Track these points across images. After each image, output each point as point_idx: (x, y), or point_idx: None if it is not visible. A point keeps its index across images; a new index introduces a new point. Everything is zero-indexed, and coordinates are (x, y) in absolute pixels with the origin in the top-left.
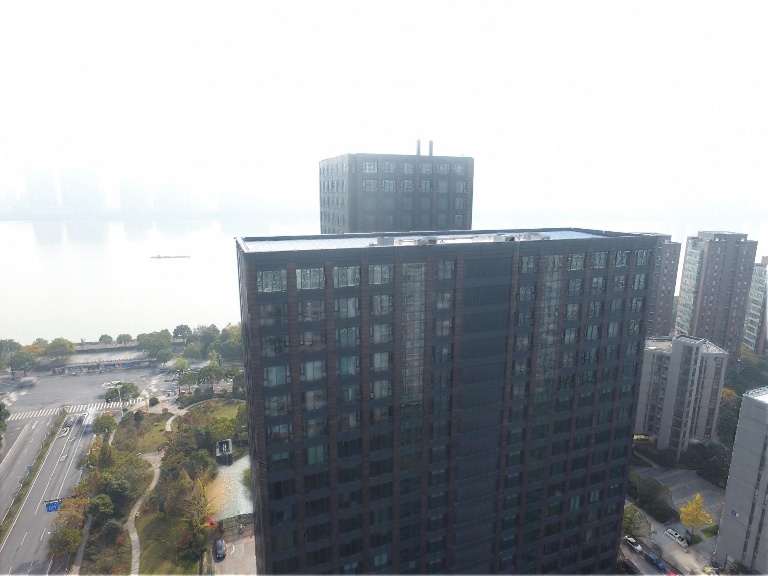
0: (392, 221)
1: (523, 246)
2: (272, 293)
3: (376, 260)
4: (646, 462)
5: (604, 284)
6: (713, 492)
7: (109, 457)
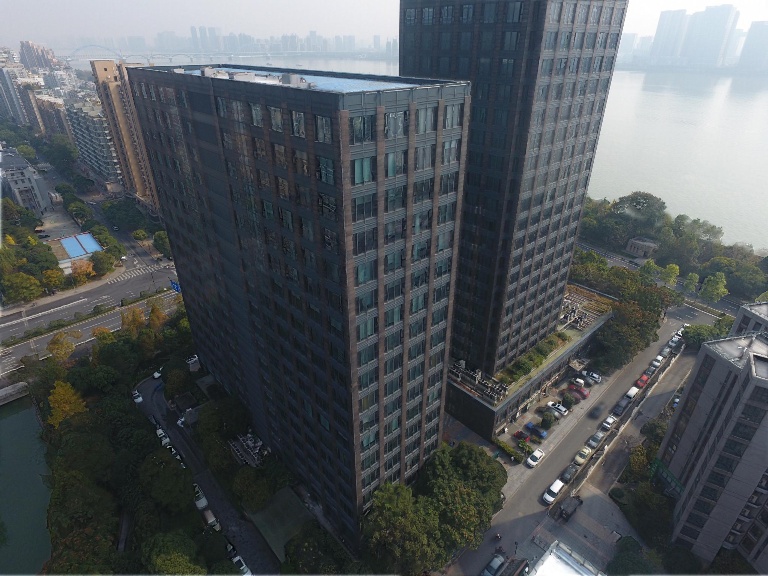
0: (430, 64)
1: (215, 84)
2: (137, 97)
3: (157, 82)
4: None
5: (286, 157)
6: None
7: None
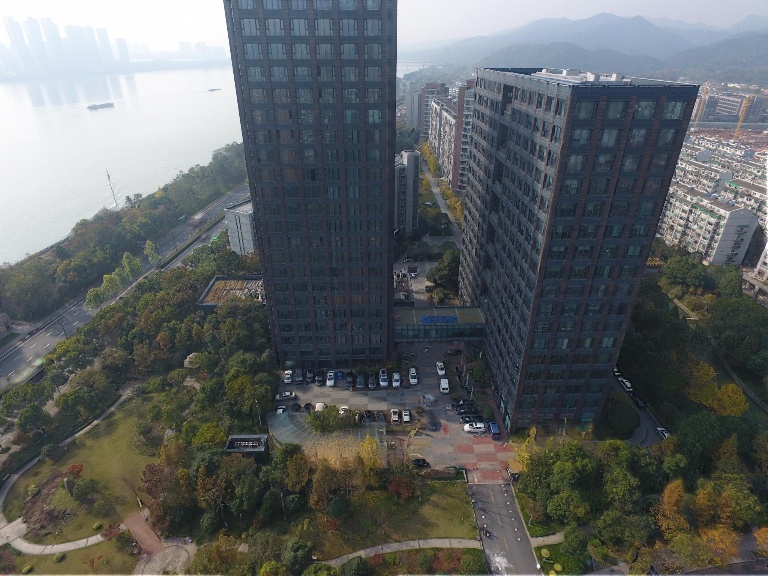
0: None
1: None
2: None
3: None
4: (413, 242)
5: None
6: (445, 239)
7: (207, 575)
